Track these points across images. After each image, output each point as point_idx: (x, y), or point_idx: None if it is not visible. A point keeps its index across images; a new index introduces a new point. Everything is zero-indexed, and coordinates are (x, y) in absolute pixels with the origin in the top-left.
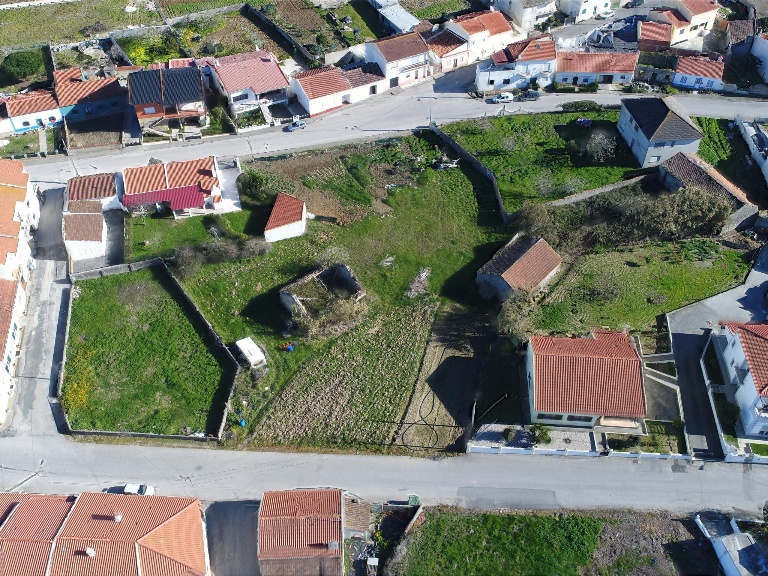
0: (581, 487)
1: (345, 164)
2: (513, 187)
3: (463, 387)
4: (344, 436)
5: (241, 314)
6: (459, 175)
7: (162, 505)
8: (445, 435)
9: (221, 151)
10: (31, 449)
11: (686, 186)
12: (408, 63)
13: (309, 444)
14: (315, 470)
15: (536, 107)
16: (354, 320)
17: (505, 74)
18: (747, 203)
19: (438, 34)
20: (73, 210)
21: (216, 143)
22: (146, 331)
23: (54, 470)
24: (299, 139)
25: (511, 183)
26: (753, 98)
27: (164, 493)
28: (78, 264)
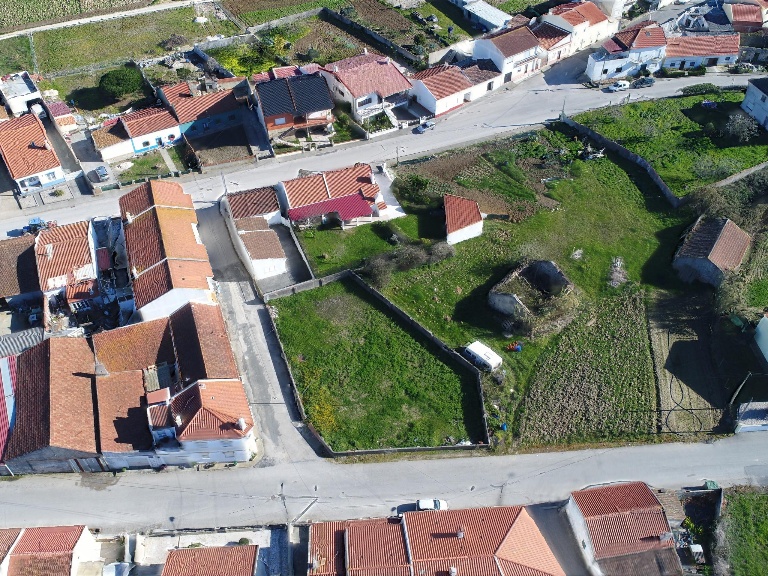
0: None
1: (491, 162)
2: (668, 172)
3: (702, 370)
4: (609, 429)
5: (454, 319)
6: (609, 164)
7: (493, 516)
8: (706, 418)
9: (359, 158)
10: (298, 476)
11: None
12: (521, 57)
13: (578, 441)
14: (596, 466)
15: (654, 93)
16: (571, 314)
17: (619, 63)
18: None
19: (537, 27)
20: (242, 228)
21: (350, 150)
22: (363, 345)
23: (332, 495)
24: (433, 140)
25: (664, 168)
26: None
27: (456, 505)
28: (262, 283)
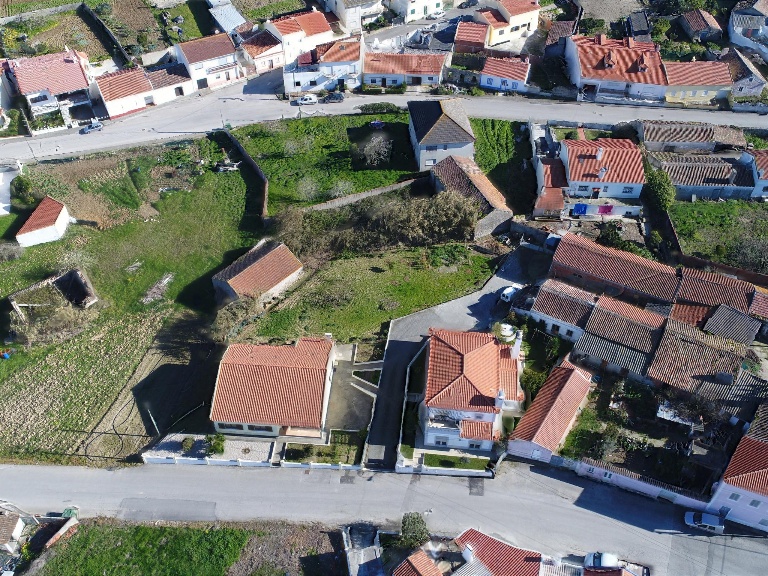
0: (244, 498)
1: (128, 167)
2: (285, 191)
3: (167, 395)
4: (29, 446)
5: None
6: (237, 178)
7: None
8: (131, 445)
9: (10, 153)
10: None
11: (447, 190)
12: (215, 64)
13: None
14: None
15: (338, 109)
16: (79, 327)
17: (310, 75)
18: (497, 208)
19: (257, 34)
20: None
21: (8, 145)
22: None
23: None
24: (92, 141)
25: (284, 187)
26: (555, 100)
27: None
28: None
